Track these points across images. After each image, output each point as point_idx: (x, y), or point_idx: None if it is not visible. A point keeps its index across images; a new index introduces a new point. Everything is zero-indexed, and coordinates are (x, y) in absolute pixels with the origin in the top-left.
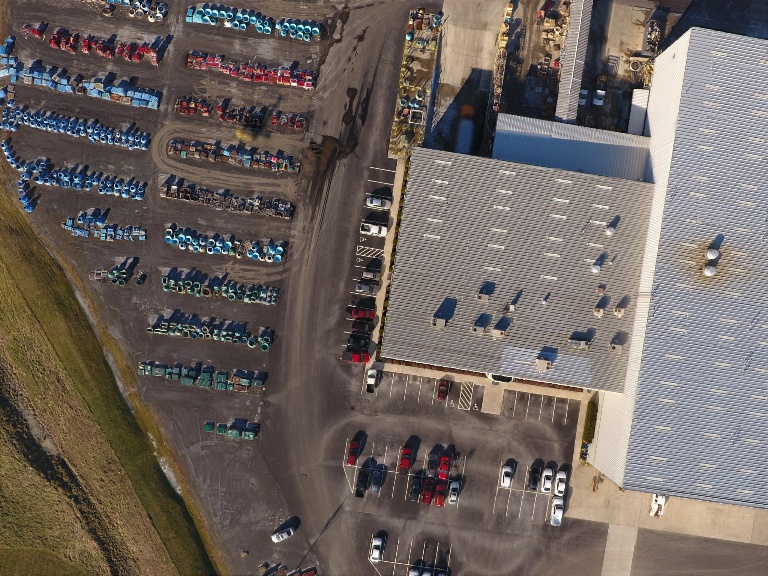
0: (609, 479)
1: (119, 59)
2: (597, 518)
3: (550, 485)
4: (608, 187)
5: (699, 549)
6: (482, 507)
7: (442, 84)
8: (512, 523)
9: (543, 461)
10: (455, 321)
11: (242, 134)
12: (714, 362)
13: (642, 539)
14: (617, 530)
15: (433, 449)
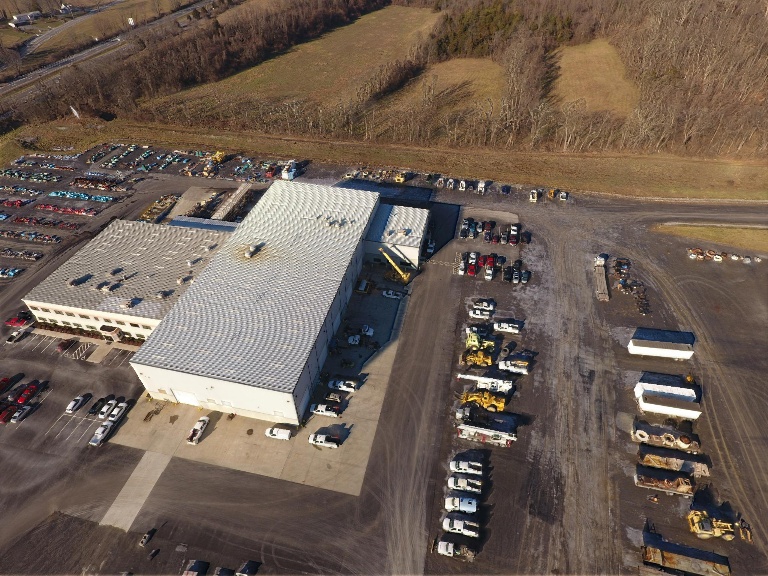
0: (164, 413)
1: (2, 205)
2: (138, 445)
3: (106, 409)
4: (217, 234)
5: (225, 481)
6: (39, 429)
7: (167, 218)
8: (57, 444)
9: (115, 396)
10: (84, 284)
11: (40, 229)
12: (236, 296)
13: (172, 467)
14: (151, 457)
15: (29, 383)
